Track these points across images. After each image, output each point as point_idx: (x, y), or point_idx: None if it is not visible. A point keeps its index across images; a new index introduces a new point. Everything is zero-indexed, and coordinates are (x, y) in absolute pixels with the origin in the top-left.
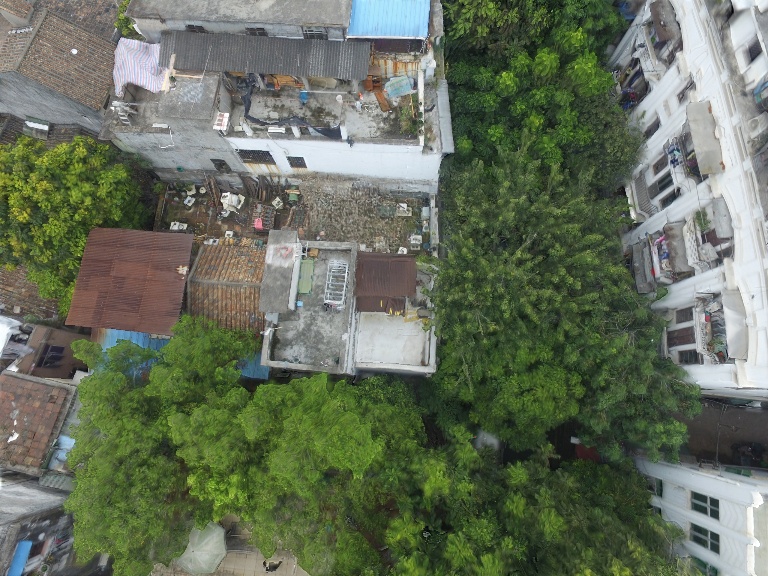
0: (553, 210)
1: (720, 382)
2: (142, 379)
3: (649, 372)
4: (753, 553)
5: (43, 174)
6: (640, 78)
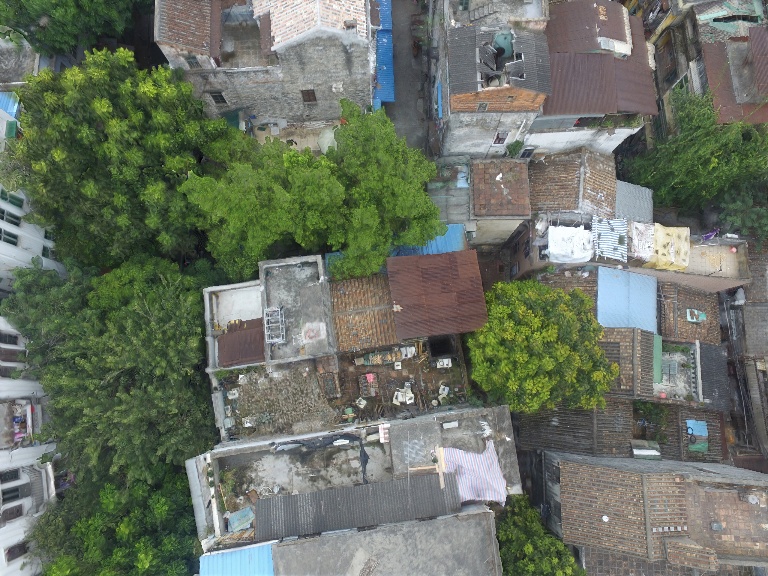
0: (90, 412)
1: None
2: (405, 226)
3: (32, 311)
4: None
5: (519, 347)
6: None
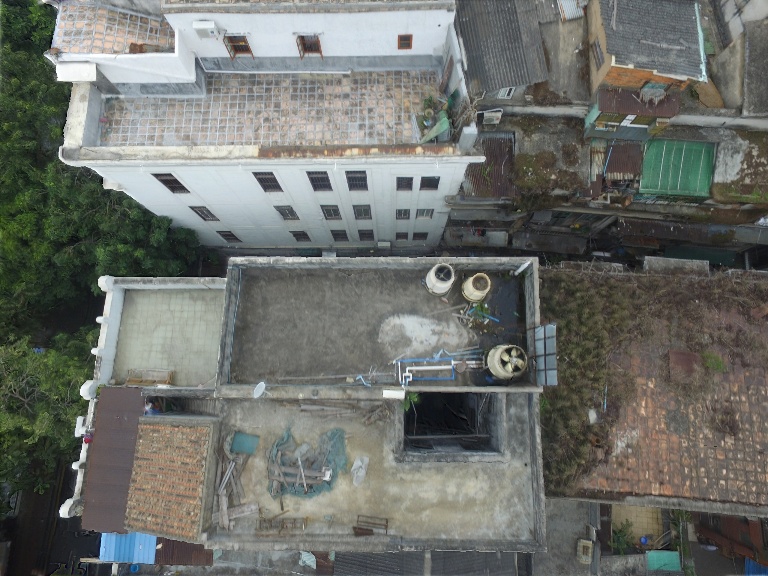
0: None
1: (146, 201)
2: None
3: (81, 200)
4: (105, 331)
5: None
6: None
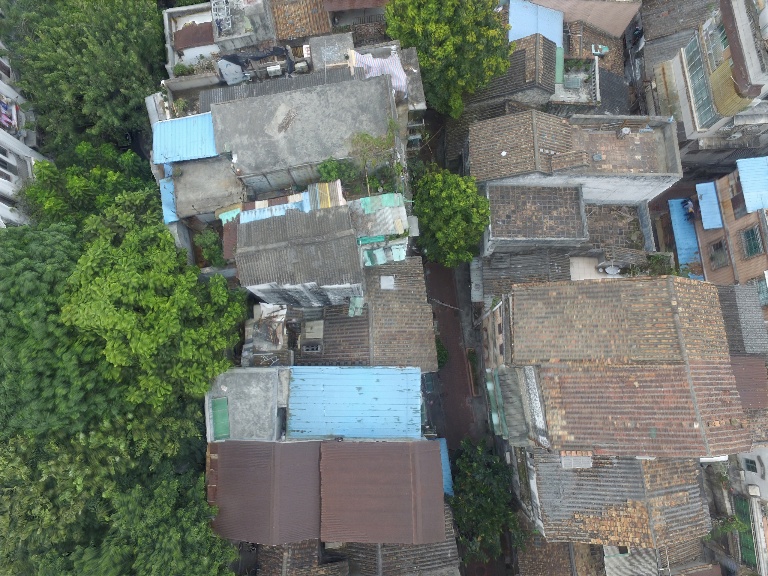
0: (63, 52)
1: None
2: None
3: (12, 7)
4: None
5: None
6: None
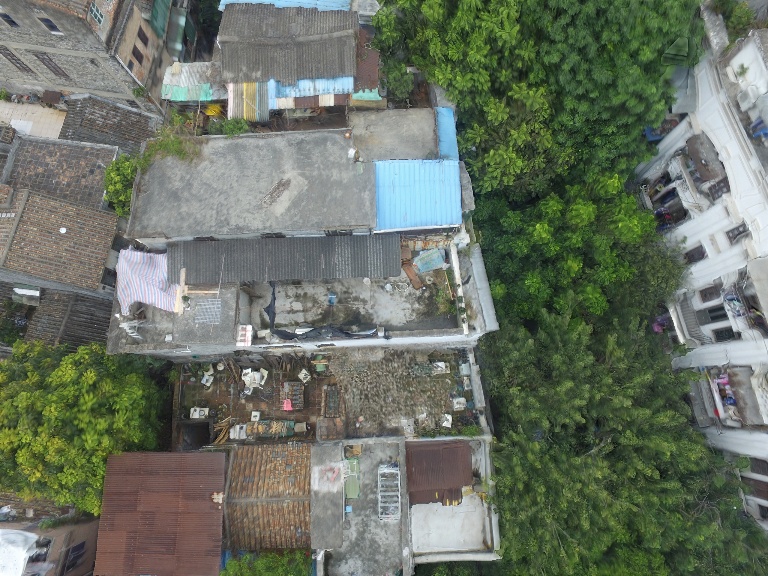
0: (622, 401)
1: None
2: None
3: (743, 560)
4: None
5: (52, 425)
6: (675, 200)
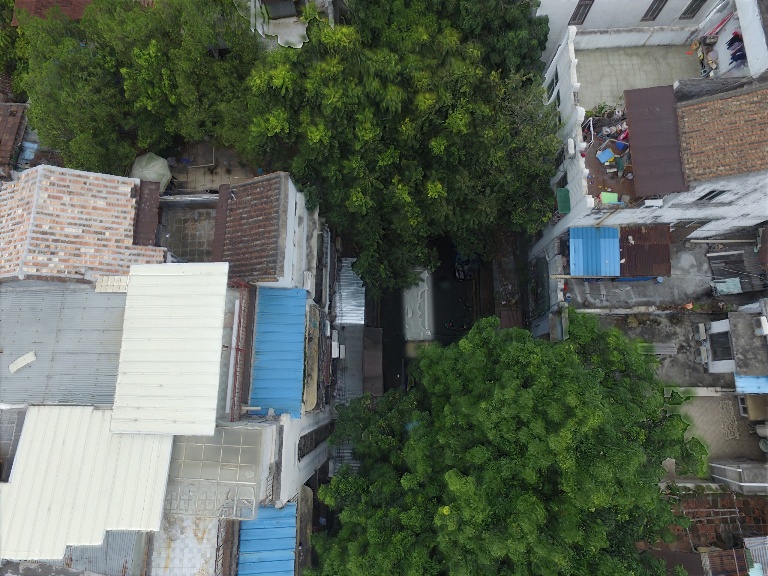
0: None
1: None
2: None
3: None
4: (575, 72)
5: None
6: None
